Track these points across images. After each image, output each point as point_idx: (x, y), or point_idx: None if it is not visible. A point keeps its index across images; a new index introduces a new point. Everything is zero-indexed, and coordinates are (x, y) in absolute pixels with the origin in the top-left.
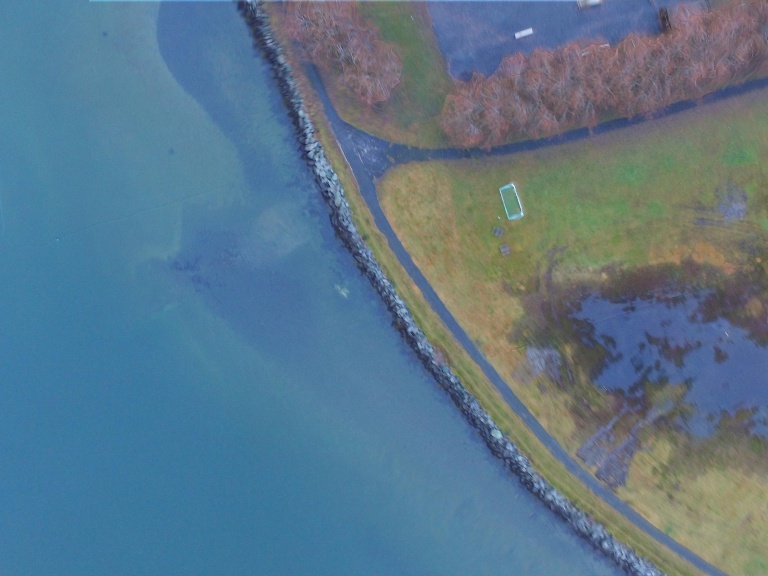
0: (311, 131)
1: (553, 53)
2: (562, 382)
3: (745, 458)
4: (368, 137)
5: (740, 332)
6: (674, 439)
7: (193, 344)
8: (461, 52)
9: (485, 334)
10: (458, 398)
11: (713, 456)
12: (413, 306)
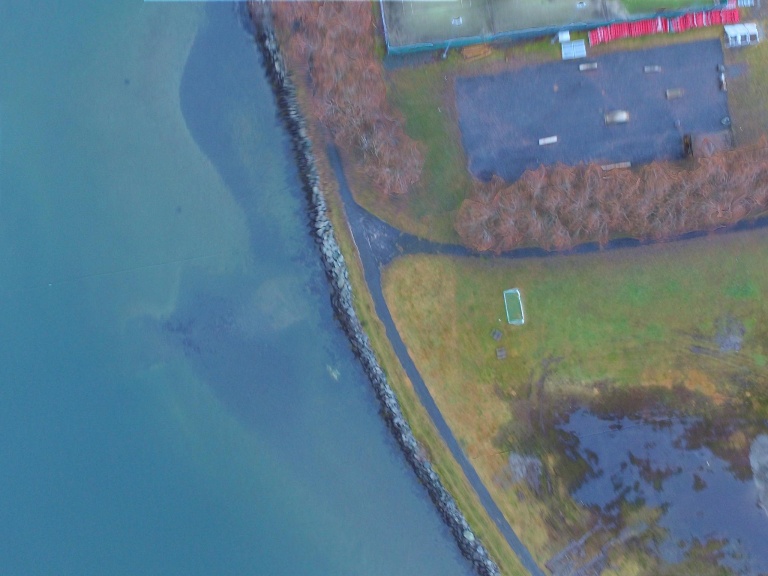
0: (323, 209)
1: (575, 167)
2: (541, 492)
3: None
4: (380, 223)
5: (721, 463)
6: (643, 561)
7: (175, 407)
8: (483, 150)
9: (471, 435)
10: (435, 495)
11: None
12: (403, 398)
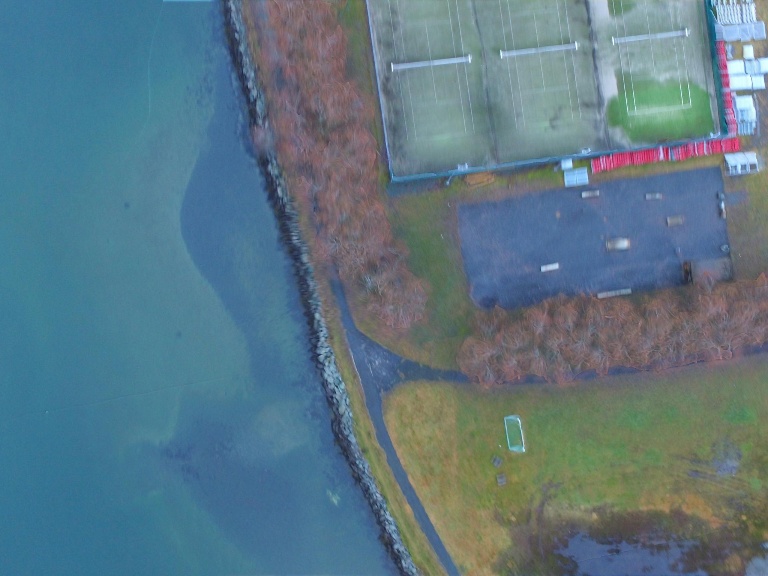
0: (325, 335)
1: (577, 300)
2: None
3: None
4: (381, 350)
5: None
6: None
7: (173, 533)
8: (486, 277)
9: (470, 560)
10: None
11: None
12: (403, 525)
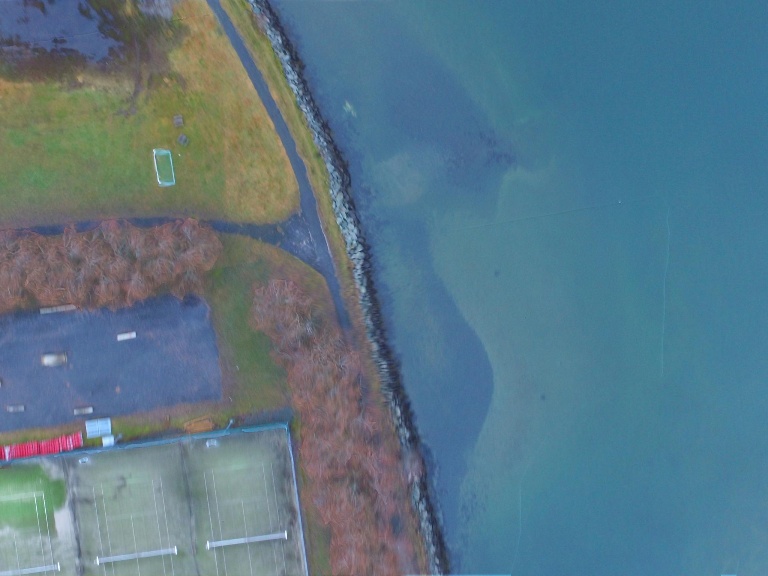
0: (357, 271)
1: (98, 305)
2: None
3: None
4: (301, 256)
5: None
6: None
7: (506, 81)
8: (194, 327)
9: (212, 40)
10: None
11: None
12: (281, 79)
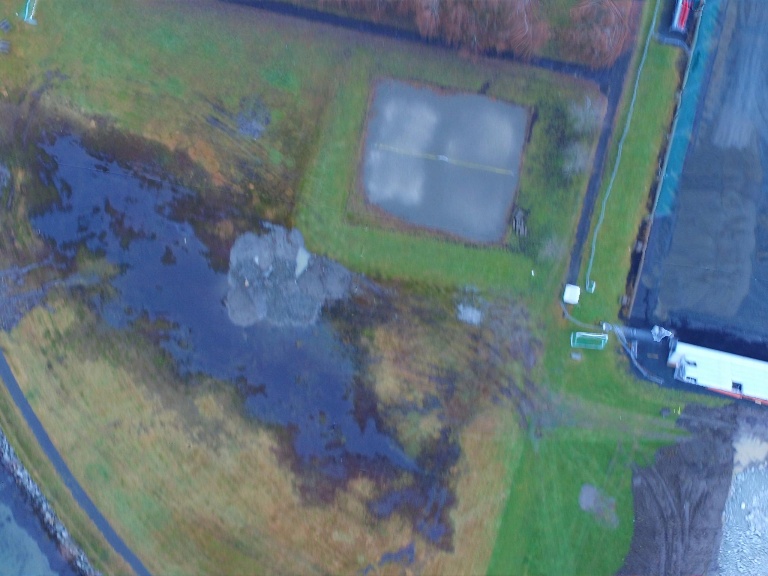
0: None
1: None
2: None
3: (143, 366)
4: None
5: (199, 245)
6: (82, 313)
7: None
8: None
9: None
10: None
11: (112, 348)
12: None
